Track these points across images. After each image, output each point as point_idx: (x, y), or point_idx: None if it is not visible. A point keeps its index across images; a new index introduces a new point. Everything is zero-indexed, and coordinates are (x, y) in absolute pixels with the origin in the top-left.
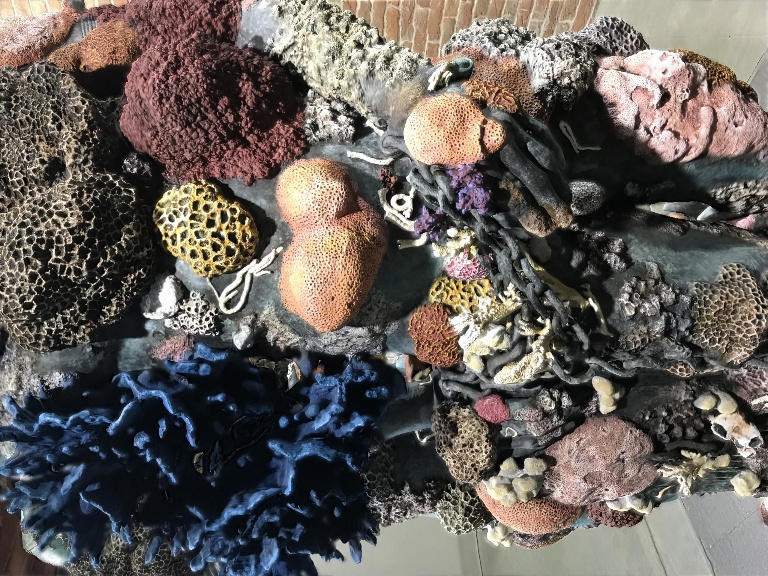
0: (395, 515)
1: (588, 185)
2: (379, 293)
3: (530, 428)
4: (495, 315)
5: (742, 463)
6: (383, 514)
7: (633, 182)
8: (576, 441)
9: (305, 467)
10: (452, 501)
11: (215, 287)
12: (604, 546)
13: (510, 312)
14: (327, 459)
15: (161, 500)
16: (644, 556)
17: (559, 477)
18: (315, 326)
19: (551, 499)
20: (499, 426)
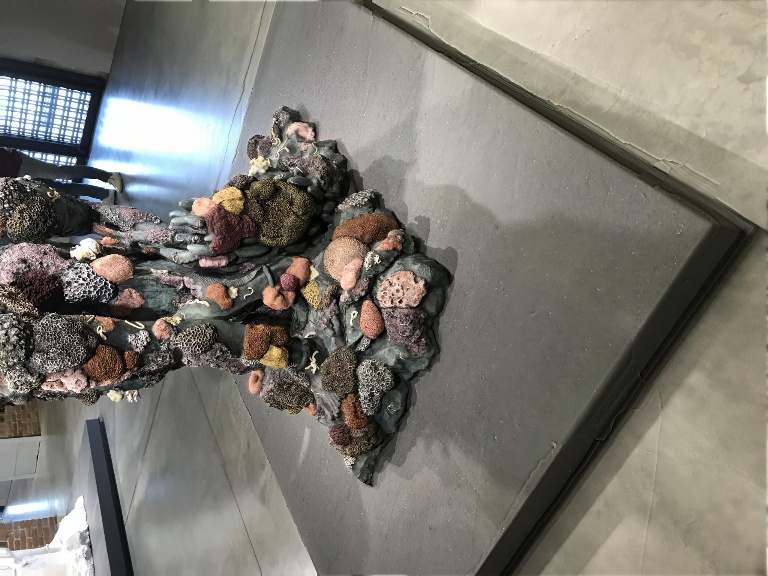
0: None
1: (23, 401)
2: None
3: None
4: None
5: None
6: None
7: None
8: None
9: None
10: None
11: None
12: (231, 28)
13: None
14: None
15: None
16: (238, 74)
17: None
18: None
19: None
20: None
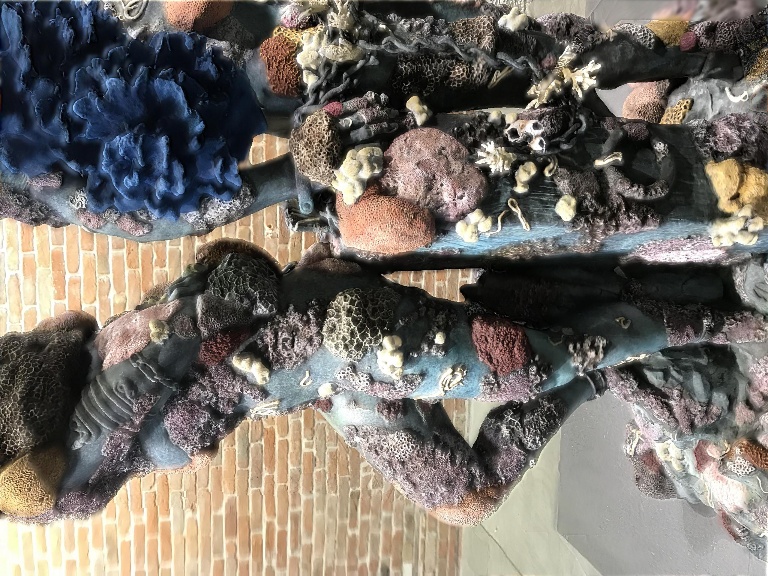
0: (283, 344)
1: None
2: (236, 20)
3: (360, 113)
4: (310, 1)
5: (556, 191)
6: (270, 341)
7: (407, 18)
8: (403, 140)
9: (175, 58)
10: (335, 315)
11: (123, 0)
12: None
13: (322, 8)
14: (191, 41)
15: (58, 77)
16: None
17: (397, 168)
18: (189, 13)
19: (398, 197)
20: (338, 120)
